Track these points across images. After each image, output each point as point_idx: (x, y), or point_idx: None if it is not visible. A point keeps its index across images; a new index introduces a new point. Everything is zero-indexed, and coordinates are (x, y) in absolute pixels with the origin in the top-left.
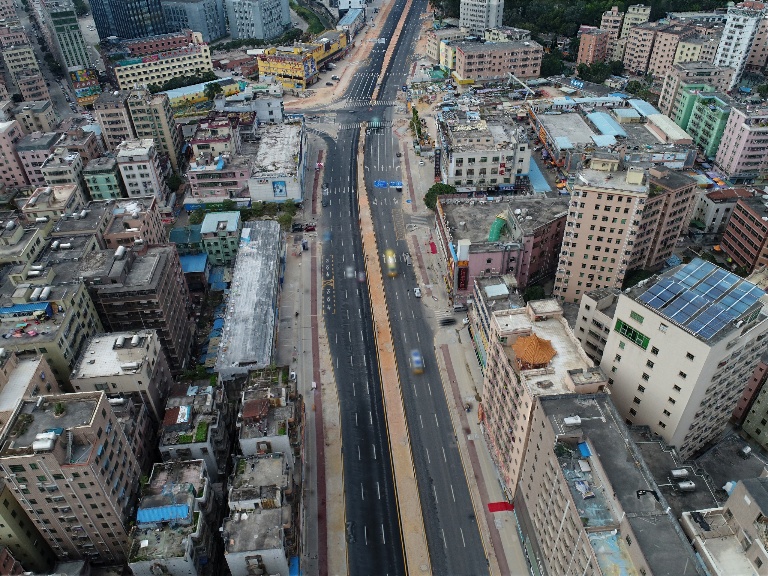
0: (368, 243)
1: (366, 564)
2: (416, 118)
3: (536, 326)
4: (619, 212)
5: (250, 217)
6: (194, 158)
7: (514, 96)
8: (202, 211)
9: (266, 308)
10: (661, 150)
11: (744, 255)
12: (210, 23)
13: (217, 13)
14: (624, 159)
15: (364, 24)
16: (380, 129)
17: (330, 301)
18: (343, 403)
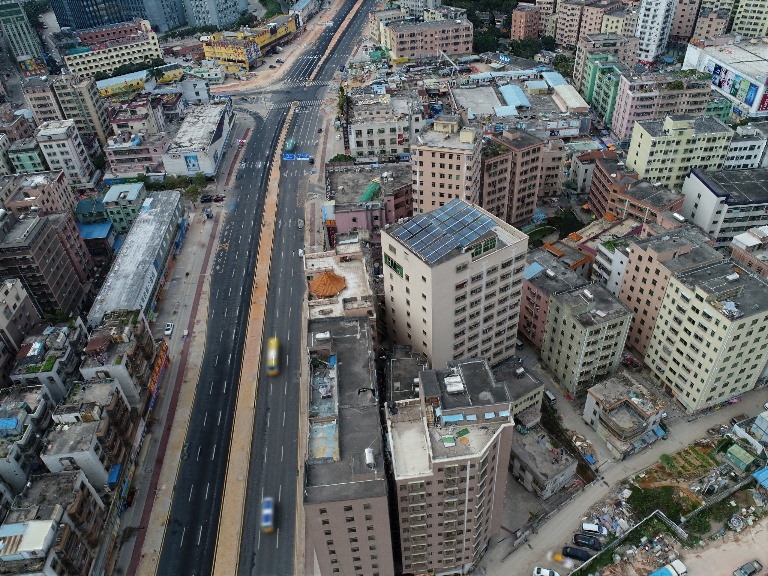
0: (269, 211)
1: (192, 476)
2: (341, 96)
3: (339, 266)
4: (452, 169)
5: (164, 190)
6: (112, 136)
7: (443, 73)
8: None
9: (147, 266)
10: (556, 118)
11: (602, 211)
12: (167, 12)
13: (174, 2)
14: None
15: (320, 8)
16: (309, 107)
17: (220, 262)
18: (208, 348)
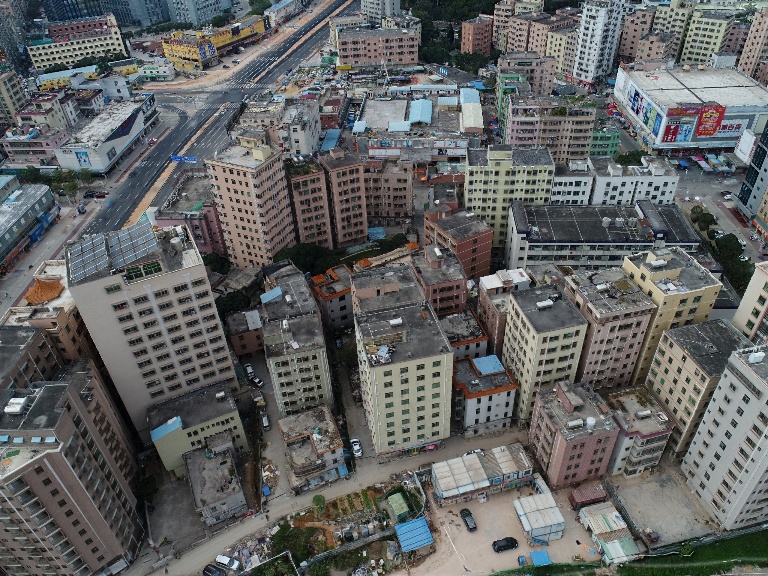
0: (138, 211)
1: None
2: None
3: None
4: (242, 185)
5: (52, 183)
6: (12, 128)
7: (379, 82)
8: None
9: None
10: (443, 137)
11: None
12: (150, 7)
13: None
14: (406, 144)
15: (303, 10)
16: None
17: None
18: None
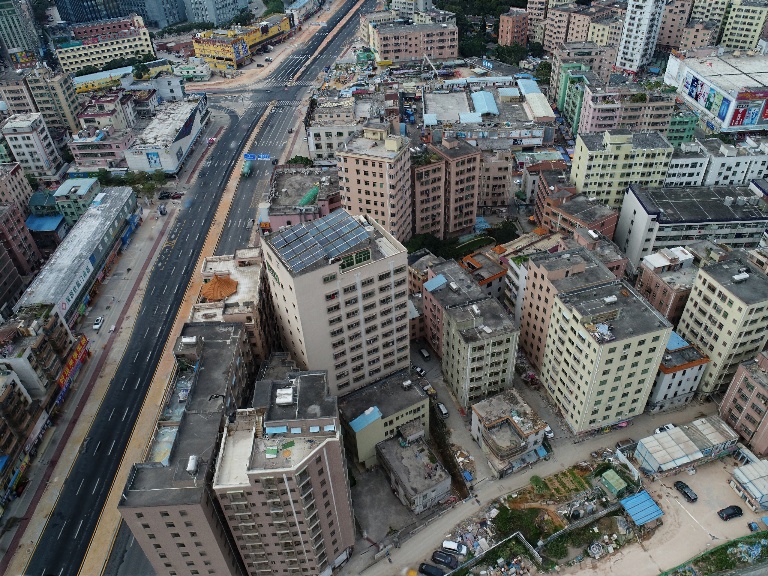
0: (222, 210)
1: (86, 470)
2: None
3: (237, 270)
4: (376, 177)
5: (124, 185)
6: (77, 131)
7: (424, 77)
8: None
9: (83, 261)
10: (519, 127)
11: None
12: (167, 8)
13: None
14: (482, 135)
15: (320, 8)
16: (286, 107)
17: (163, 259)
18: (131, 344)
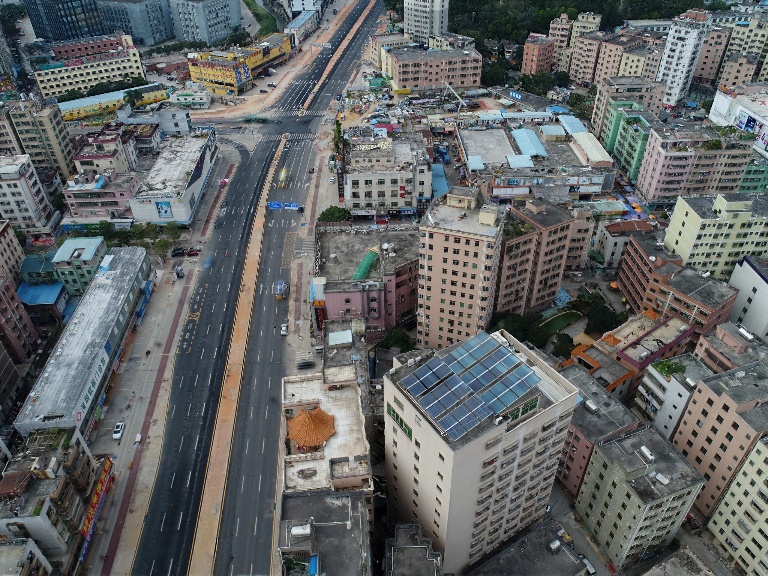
0: (249, 271)
1: None
2: (336, 131)
3: (327, 396)
4: (469, 256)
5: (130, 240)
6: (73, 176)
7: (448, 108)
8: (78, 233)
9: (97, 350)
10: (576, 173)
11: (635, 296)
12: (154, 24)
13: (162, 14)
14: (536, 182)
15: (318, 27)
16: (301, 142)
17: (188, 338)
18: (164, 460)
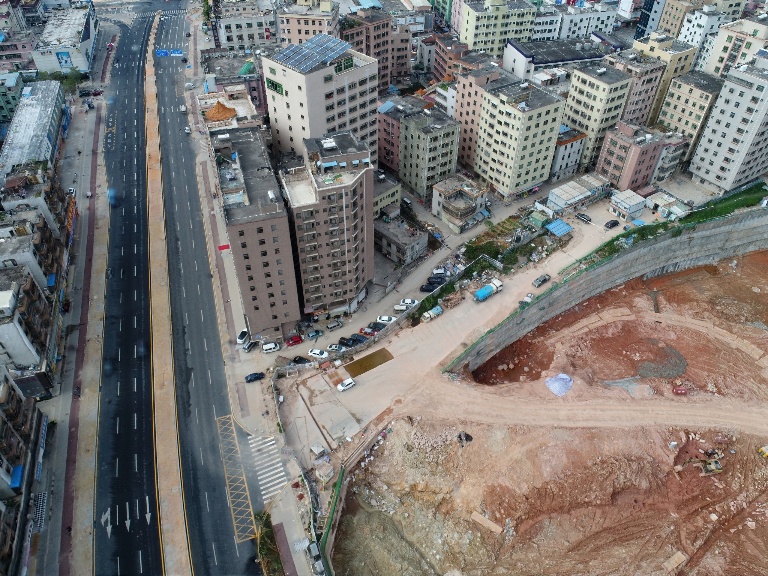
0: (150, 100)
1: (120, 288)
2: (205, 3)
3: (229, 103)
4: None
5: None
6: None
7: None
8: None
9: (41, 138)
10: (404, 15)
11: None
12: None
13: None
14: None
15: None
16: None
17: (110, 142)
18: (113, 203)
